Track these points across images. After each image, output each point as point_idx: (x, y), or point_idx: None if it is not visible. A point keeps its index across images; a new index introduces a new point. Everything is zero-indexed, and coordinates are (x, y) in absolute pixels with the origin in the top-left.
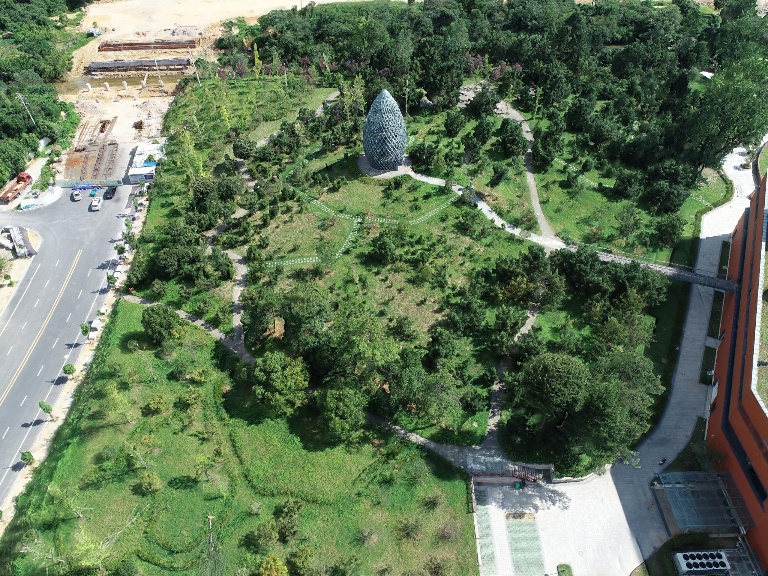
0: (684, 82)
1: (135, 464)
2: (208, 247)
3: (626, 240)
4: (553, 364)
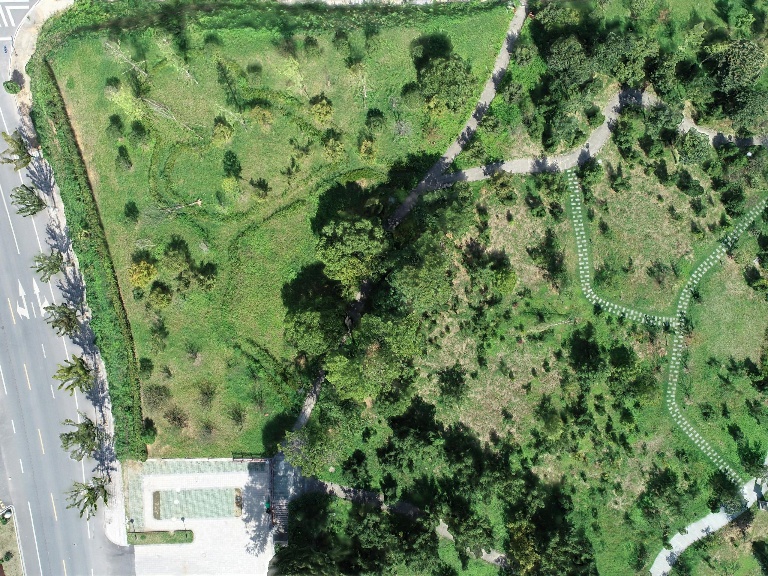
0: None
1: (228, 115)
2: (617, 101)
3: None
4: None
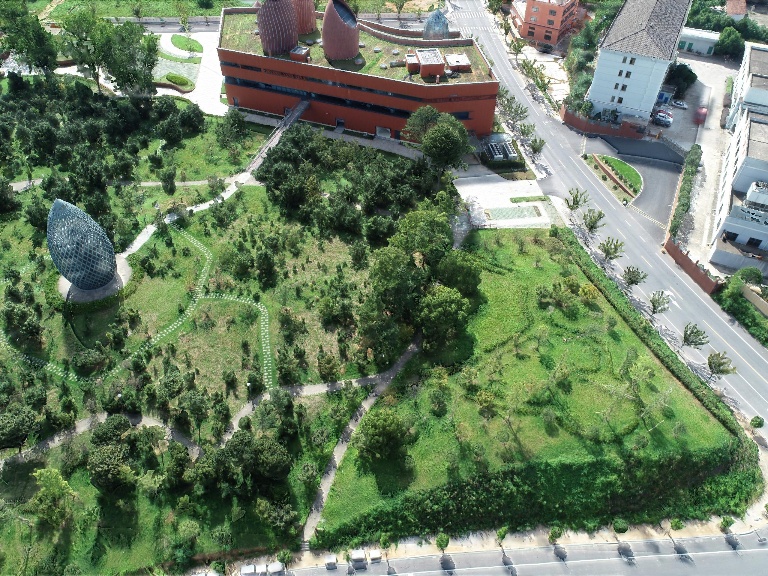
0: (20, 78)
1: None
2: None
3: (241, 144)
4: (444, 131)
